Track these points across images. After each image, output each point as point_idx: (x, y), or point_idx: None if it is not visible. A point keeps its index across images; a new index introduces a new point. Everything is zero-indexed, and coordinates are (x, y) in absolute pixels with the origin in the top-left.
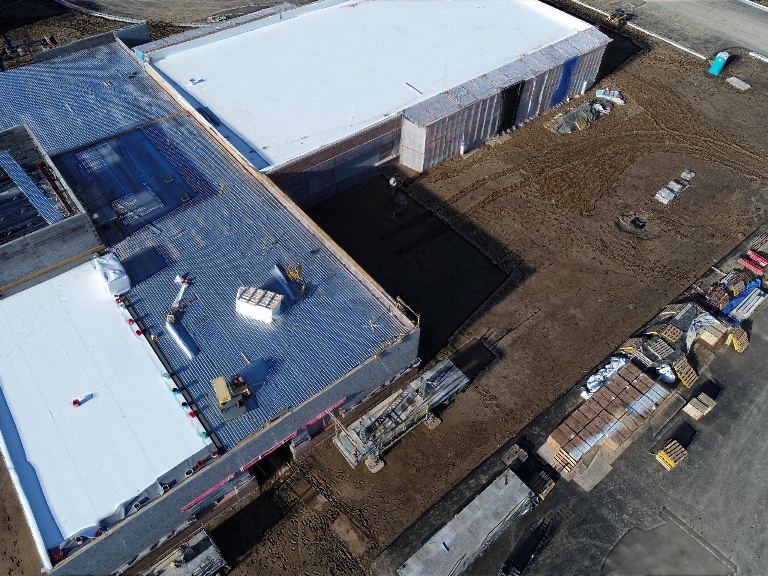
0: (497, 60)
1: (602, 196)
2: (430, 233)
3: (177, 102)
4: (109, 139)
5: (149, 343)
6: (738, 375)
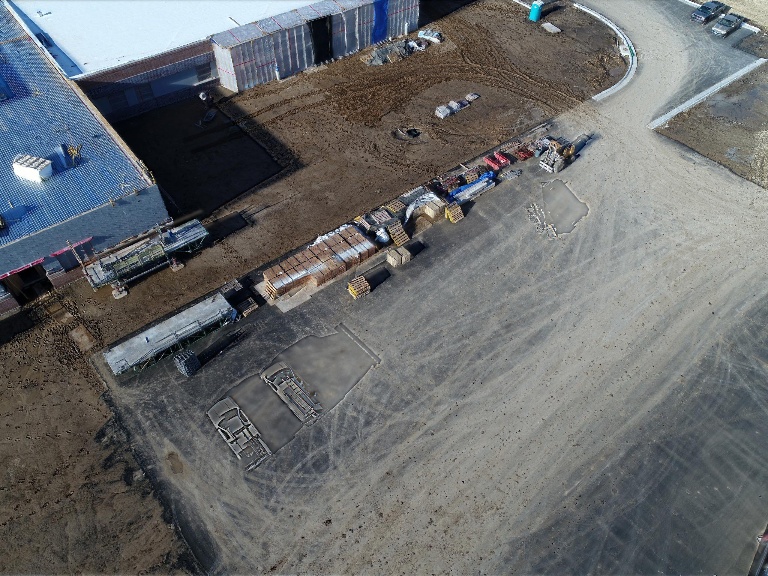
0: (318, 1)
1: (390, 112)
2: (228, 137)
3: (24, 30)
4: None
5: None
6: (444, 238)
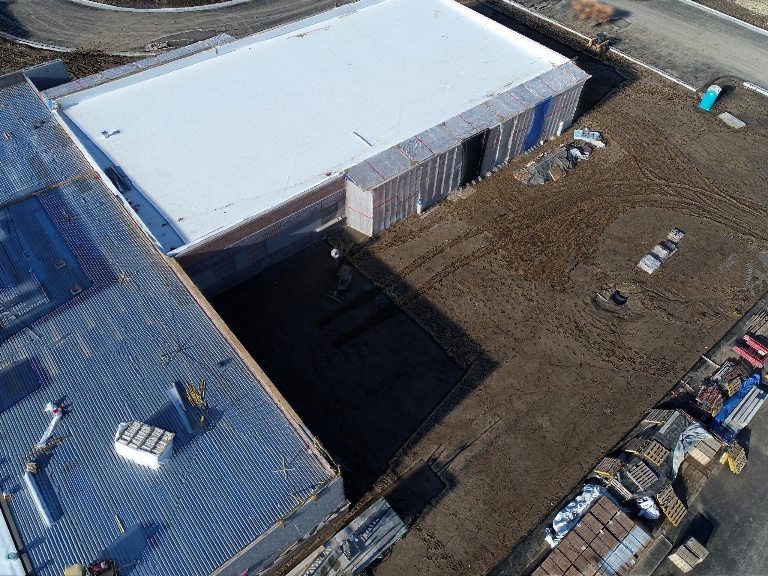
0: (460, 102)
1: (578, 264)
2: (376, 316)
3: (86, 159)
4: None
5: None
6: (734, 506)
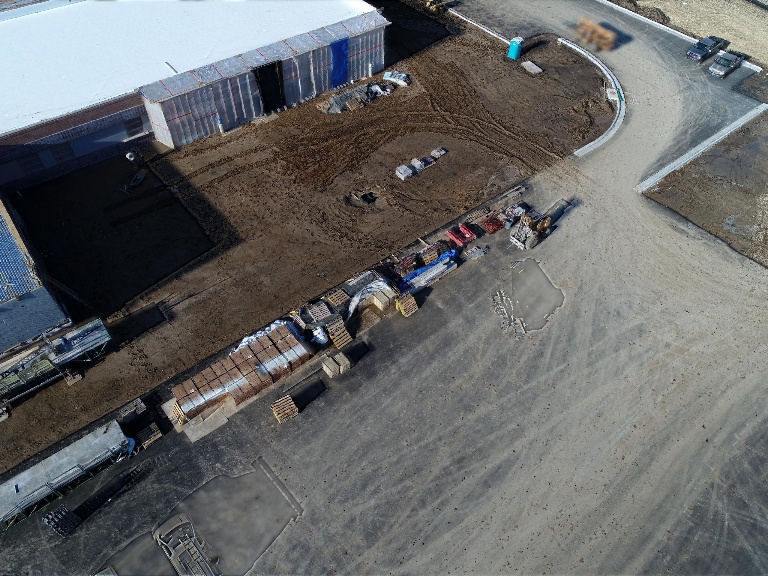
0: (269, 42)
1: (344, 172)
2: (156, 205)
3: None
4: None
5: None
6: (394, 338)
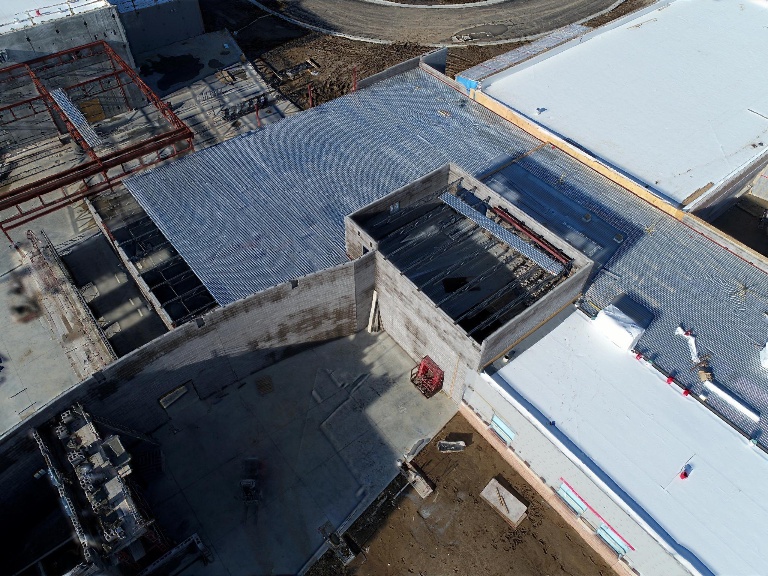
0: None
1: None
2: None
3: (528, 132)
4: (493, 174)
5: (703, 405)
6: None
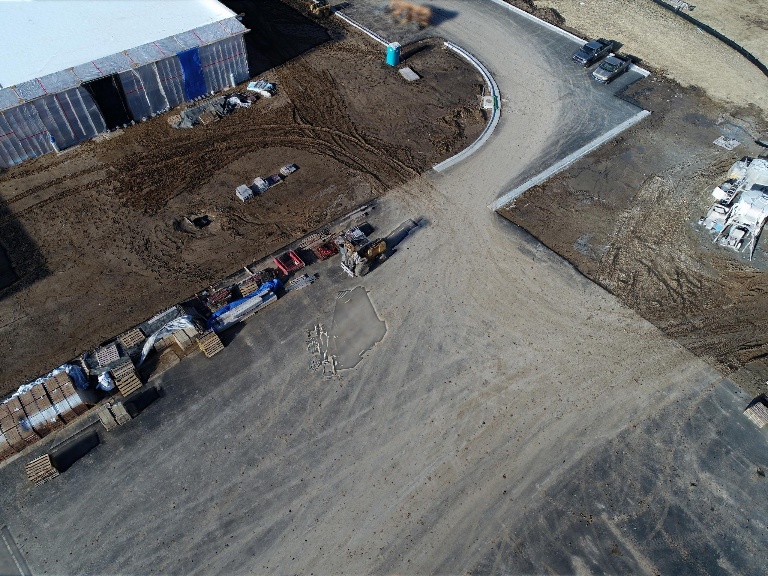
0: (114, 52)
1: (181, 193)
2: None
3: None
4: None
5: None
6: (189, 382)
